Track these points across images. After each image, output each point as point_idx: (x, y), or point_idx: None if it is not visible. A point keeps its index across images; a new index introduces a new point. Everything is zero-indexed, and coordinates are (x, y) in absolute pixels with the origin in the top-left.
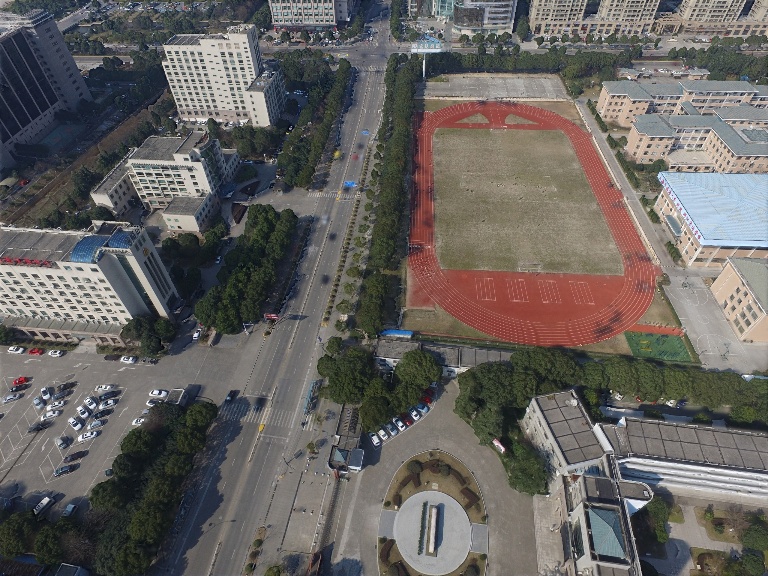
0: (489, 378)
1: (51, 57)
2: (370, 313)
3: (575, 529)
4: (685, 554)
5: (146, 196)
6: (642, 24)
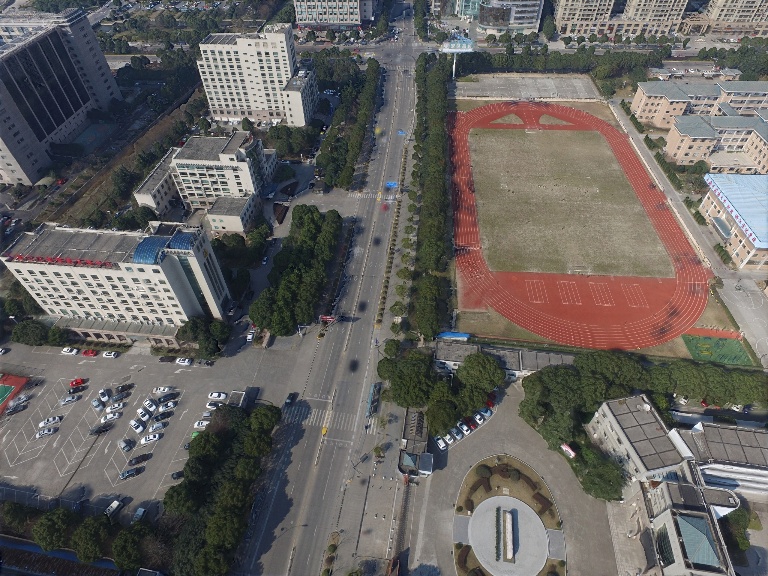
0: (557, 382)
1: (85, 56)
2: (426, 315)
3: (659, 536)
4: (767, 561)
5: (188, 196)
6: (669, 24)
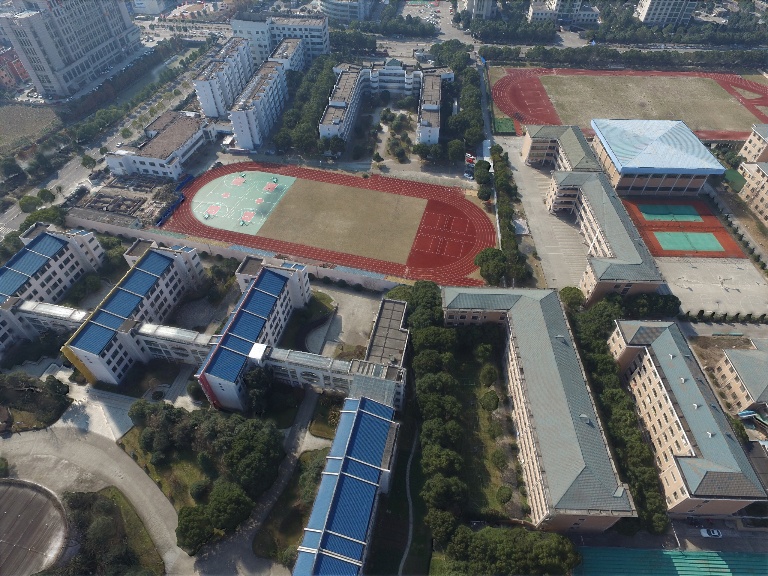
0: None
1: None
2: None
3: None
4: None
5: None
6: None
